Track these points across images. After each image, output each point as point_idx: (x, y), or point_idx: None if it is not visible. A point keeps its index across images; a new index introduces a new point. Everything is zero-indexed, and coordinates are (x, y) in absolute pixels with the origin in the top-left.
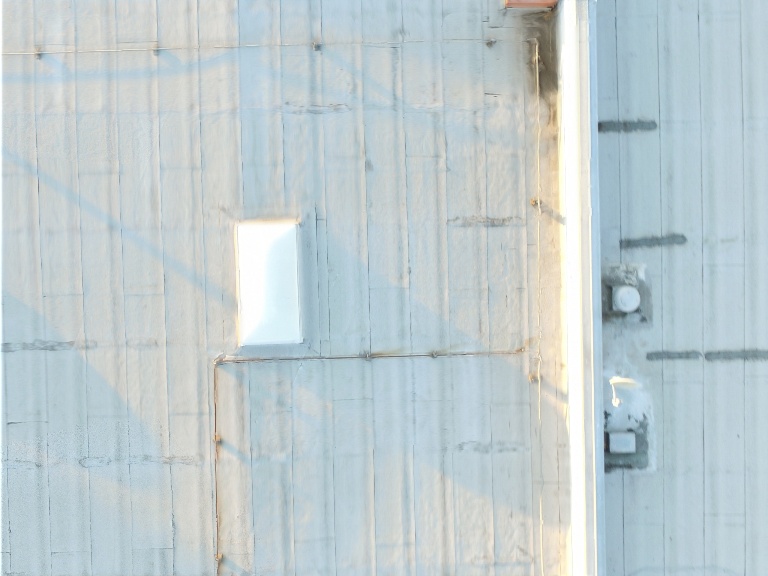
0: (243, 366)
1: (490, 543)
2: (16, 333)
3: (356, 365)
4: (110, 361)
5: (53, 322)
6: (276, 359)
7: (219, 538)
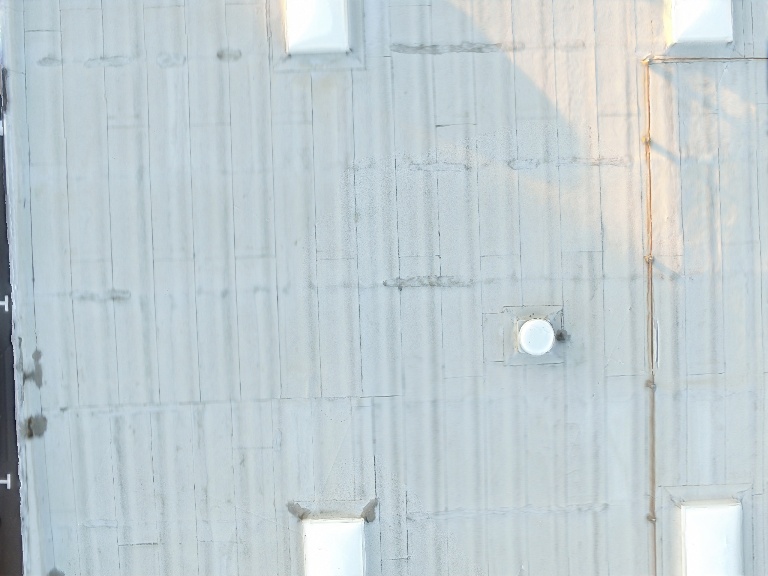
0: (671, 66)
1: None
2: (444, 35)
3: None
4: (538, 63)
5: (481, 24)
6: (706, 58)
7: (648, 240)
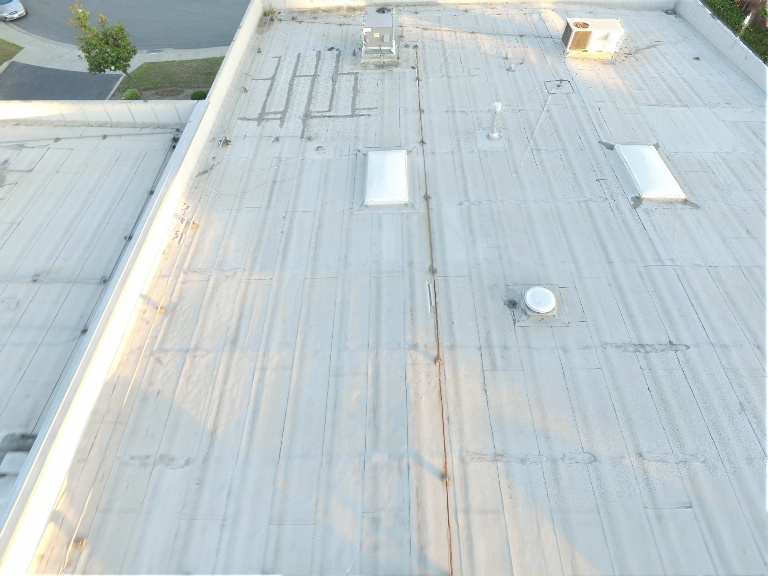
0: None
1: (186, 368)
2: None
3: (282, 572)
4: None
5: None
6: None
7: (440, 379)
